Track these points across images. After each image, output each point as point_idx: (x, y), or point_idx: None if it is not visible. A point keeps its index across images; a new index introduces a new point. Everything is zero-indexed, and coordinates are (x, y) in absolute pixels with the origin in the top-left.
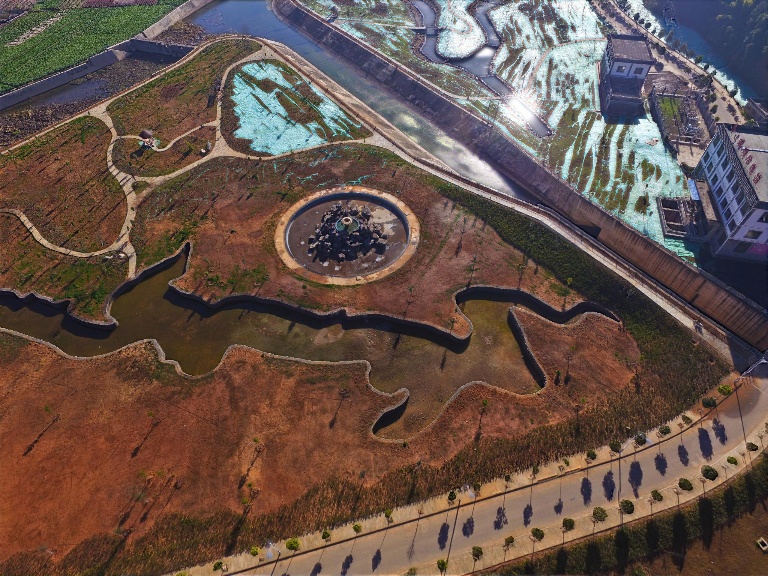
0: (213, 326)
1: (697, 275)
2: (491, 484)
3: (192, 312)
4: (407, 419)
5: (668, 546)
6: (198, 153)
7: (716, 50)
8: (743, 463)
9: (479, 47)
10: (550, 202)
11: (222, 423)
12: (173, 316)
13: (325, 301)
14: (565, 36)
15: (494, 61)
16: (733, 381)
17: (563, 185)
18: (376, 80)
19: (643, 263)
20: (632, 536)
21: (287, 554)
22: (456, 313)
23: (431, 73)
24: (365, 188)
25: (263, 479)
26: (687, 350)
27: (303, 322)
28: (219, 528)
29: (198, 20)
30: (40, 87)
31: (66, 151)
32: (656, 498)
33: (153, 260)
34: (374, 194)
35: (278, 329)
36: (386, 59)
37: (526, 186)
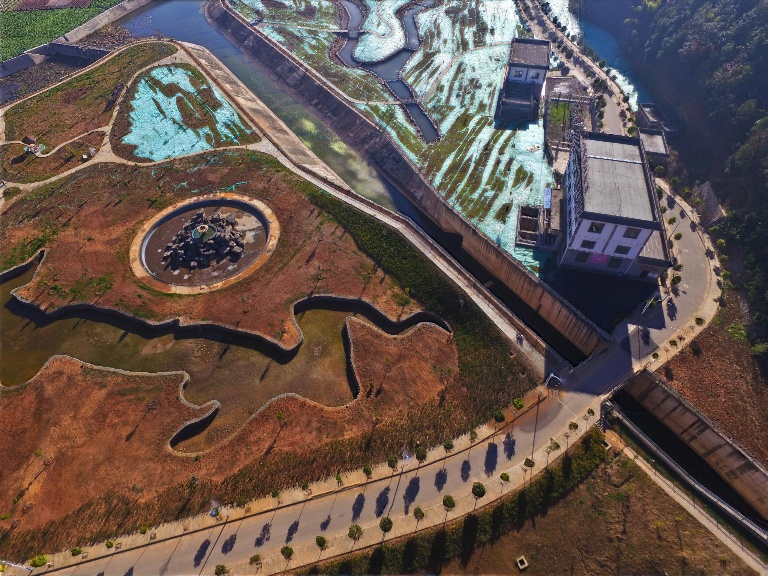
0: (45, 336)
1: (537, 285)
2: (265, 500)
3: (28, 321)
4: (211, 432)
5: (423, 565)
6: (79, 159)
7: (624, 54)
8: (523, 479)
9: (396, 51)
10: (424, 209)
11: (19, 435)
12: (8, 325)
13: (161, 310)
14: (482, 40)
15: (406, 65)
16: (538, 394)
17: (432, 192)
18: (286, 84)
19: (498, 272)
20: (389, 554)
21: (39, 571)
22: (289, 323)
23: (339, 77)
24: (237, 195)
25: (41, 493)
26: (502, 362)
27: (136, 332)
28: None
29: (127, 23)
30: None
31: None
32: (417, 516)
33: (2, 268)
34: (244, 201)
35: (109, 339)
36: (298, 63)
37: (405, 193)
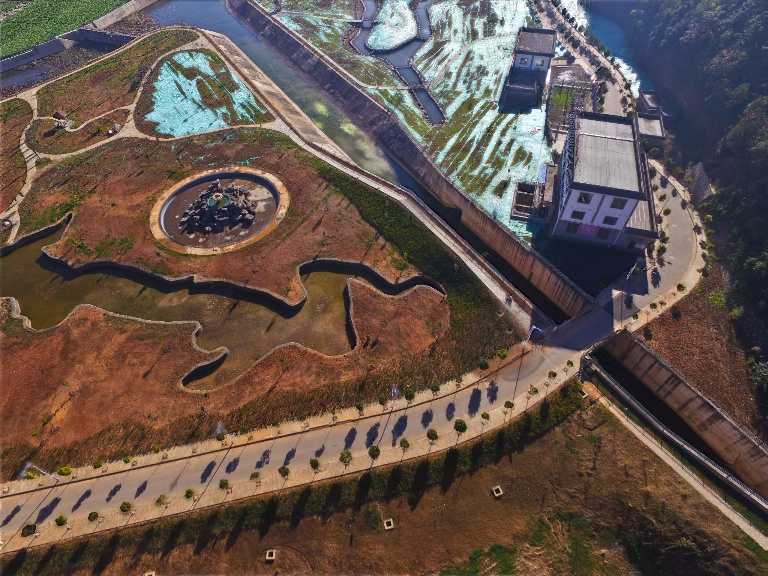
0: (72, 288)
1: (529, 253)
2: (266, 430)
3: (57, 275)
4: (219, 374)
5: (407, 489)
6: (105, 134)
7: (630, 44)
8: (503, 420)
9: (408, 40)
10: (427, 186)
11: (48, 370)
12: (39, 278)
13: (177, 268)
14: (491, 30)
15: (417, 53)
16: (522, 348)
17: (434, 169)
18: (301, 70)
19: (493, 243)
20: (376, 479)
21: (64, 481)
22: (295, 282)
23: (352, 64)
24: (250, 168)
25: (67, 419)
26: (491, 320)
27: (154, 287)
28: (13, 457)
29: (152, 12)
30: None
31: None
32: (403, 445)
33: (34, 228)
34: (257, 174)
35: (129, 292)
36: (313, 50)
37: (409, 171)
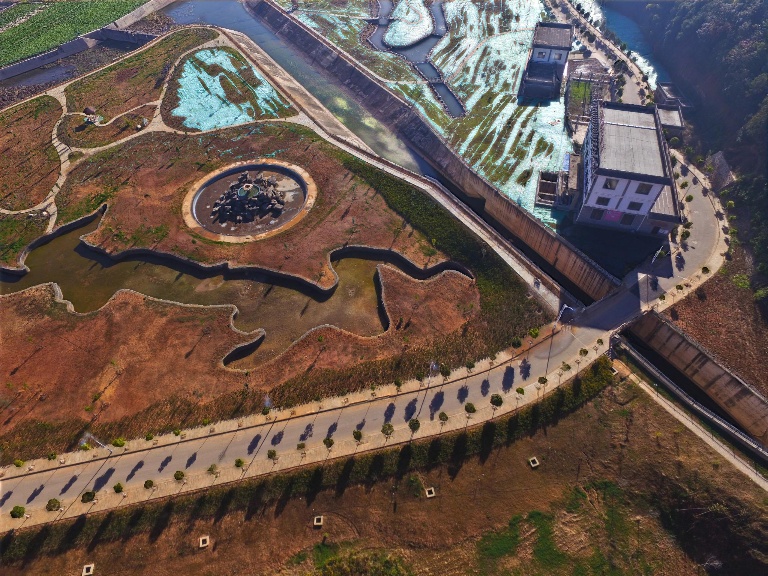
0: (111, 274)
1: (554, 239)
2: (308, 405)
3: (95, 262)
4: (258, 354)
5: (447, 460)
6: (134, 128)
7: (646, 38)
8: (536, 396)
9: (424, 36)
10: (449, 176)
11: (94, 351)
12: (78, 265)
13: (212, 255)
14: (507, 26)
15: (434, 49)
16: (552, 328)
17: (457, 159)
18: (320, 66)
19: (517, 231)
20: (417, 450)
21: (117, 453)
22: (326, 268)
23: (370, 60)
24: (277, 160)
25: (115, 395)
26: (520, 302)
27: (190, 273)
28: (67, 431)
29: (171, 12)
30: (12, 71)
31: (19, 125)
32: (442, 418)
33: (71, 218)
34: (284, 166)
35: (166, 278)
36: (331, 47)
37: (432, 162)
